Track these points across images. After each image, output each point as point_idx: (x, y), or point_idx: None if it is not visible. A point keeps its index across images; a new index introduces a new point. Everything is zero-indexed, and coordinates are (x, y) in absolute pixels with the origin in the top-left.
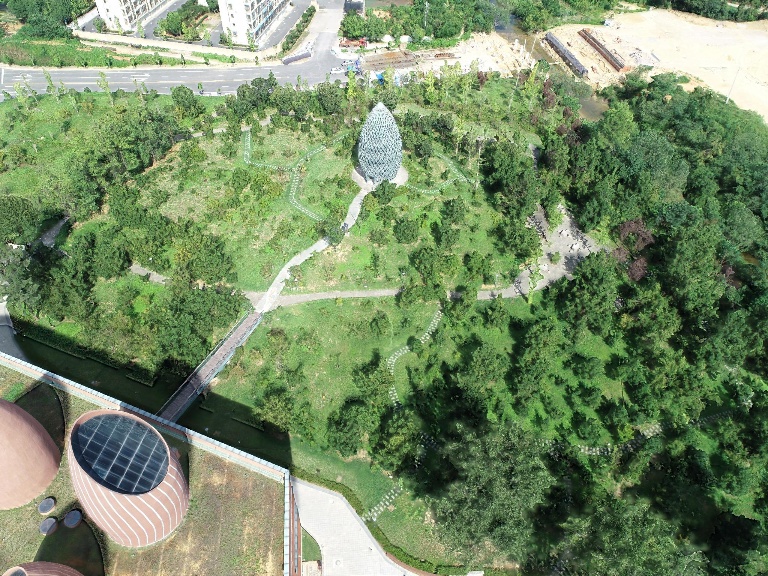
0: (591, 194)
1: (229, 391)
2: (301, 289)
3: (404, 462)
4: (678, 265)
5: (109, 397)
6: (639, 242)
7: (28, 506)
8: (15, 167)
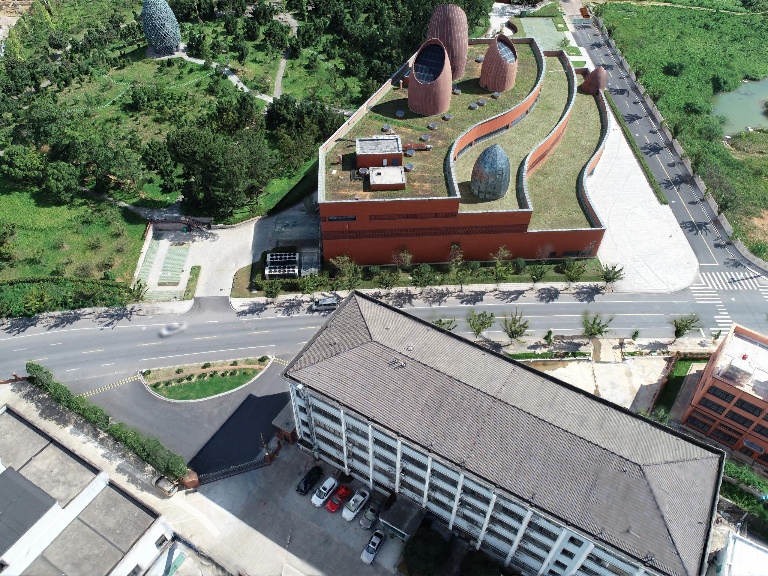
0: None
1: (344, 117)
2: (271, 88)
3: None
4: None
5: (387, 82)
6: None
7: None
8: None
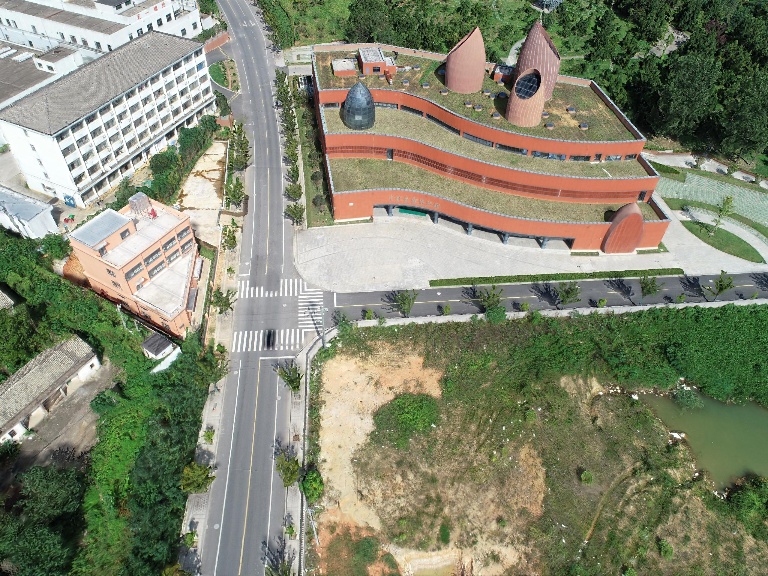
0: (685, 10)
1: None
2: None
3: (624, 107)
4: (747, 31)
5: (488, 62)
6: (718, 31)
7: (477, 93)
8: (312, 6)
